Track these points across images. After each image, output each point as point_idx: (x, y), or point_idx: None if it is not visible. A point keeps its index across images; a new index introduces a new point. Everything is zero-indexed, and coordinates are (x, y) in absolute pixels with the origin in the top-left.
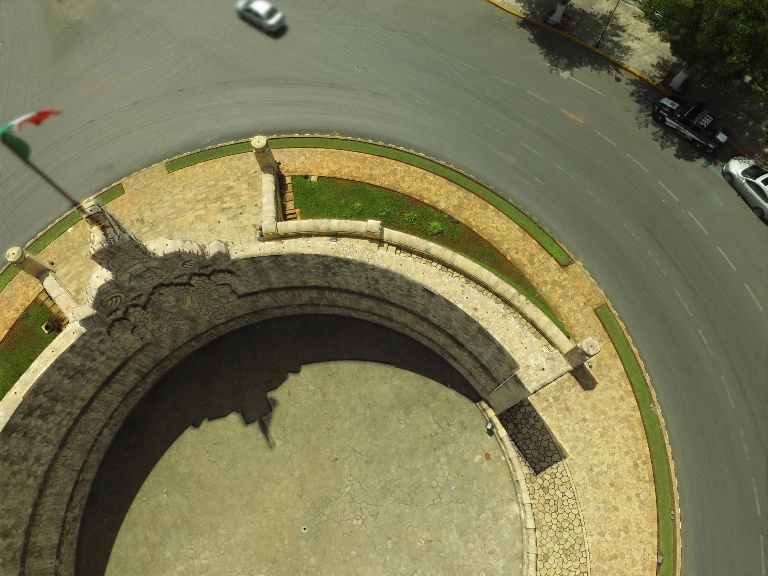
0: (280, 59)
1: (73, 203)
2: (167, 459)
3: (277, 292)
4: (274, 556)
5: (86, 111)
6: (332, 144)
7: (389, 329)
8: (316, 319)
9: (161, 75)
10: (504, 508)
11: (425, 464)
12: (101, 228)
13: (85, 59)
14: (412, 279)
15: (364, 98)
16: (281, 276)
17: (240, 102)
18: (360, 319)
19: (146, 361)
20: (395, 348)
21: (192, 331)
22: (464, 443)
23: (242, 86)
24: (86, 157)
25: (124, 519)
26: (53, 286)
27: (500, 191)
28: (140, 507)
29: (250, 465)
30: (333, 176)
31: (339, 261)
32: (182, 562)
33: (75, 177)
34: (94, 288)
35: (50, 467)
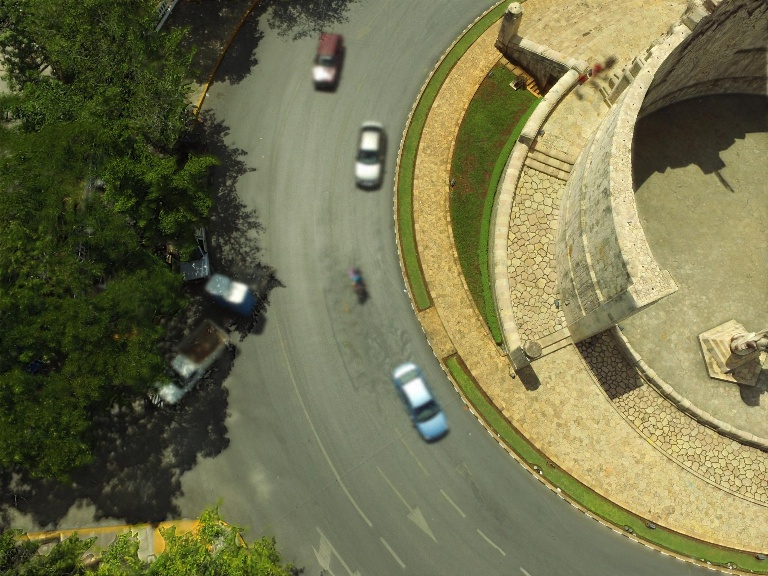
0: None
1: None
2: (641, 195)
3: (766, 52)
4: (749, 273)
5: None
6: None
7: None
8: (751, 99)
9: None
10: None
11: None
12: None
13: None
14: None
15: None
16: None
17: None
18: None
19: (644, 103)
20: None
21: (675, 85)
22: None
23: None
24: None
25: None
26: (536, 44)
27: None
28: None
29: (714, 205)
30: None
31: None
32: (670, 270)
33: None
34: None
35: None
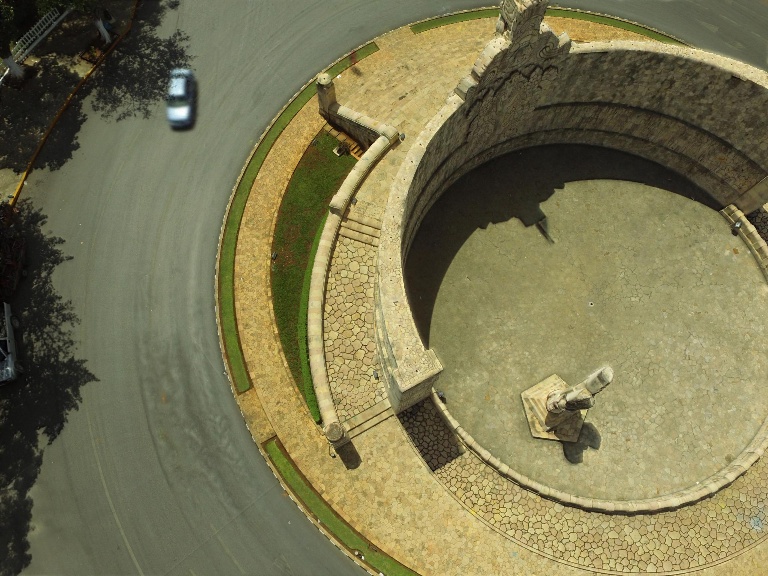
0: None
1: (334, 57)
2: (463, 253)
3: (564, 107)
4: (570, 324)
5: None
6: (555, 13)
7: (634, 156)
8: (569, 148)
9: None
10: (756, 288)
11: (684, 257)
12: None
13: None
14: (723, 68)
15: None
16: (582, 85)
17: None
18: (608, 148)
19: (453, 164)
20: (642, 170)
21: (484, 144)
22: (714, 241)
23: None
24: (338, 20)
25: (436, 297)
26: (351, 111)
27: None
28: (448, 288)
29: (535, 257)
30: None
31: (653, 59)
32: (493, 328)
33: (332, 36)
34: (490, 57)
35: (405, 232)
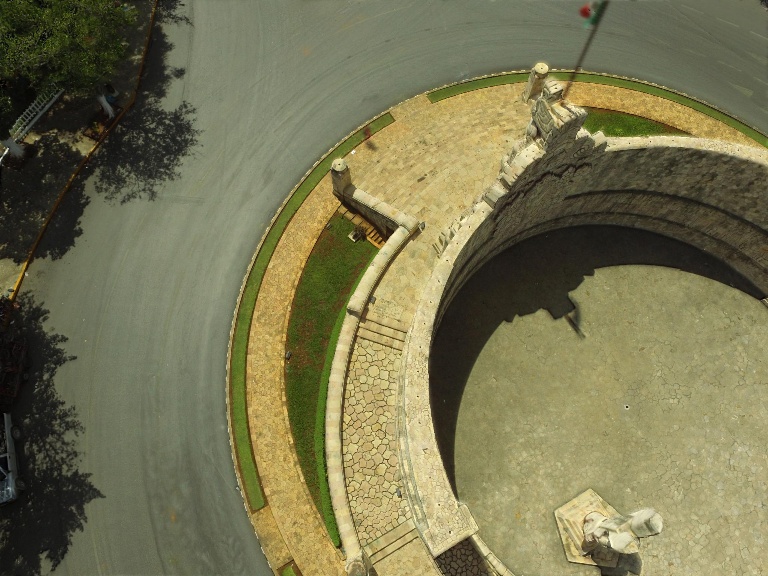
0: (515, 2)
1: (348, 130)
2: (489, 349)
3: (595, 195)
4: (605, 430)
5: (342, 48)
6: (579, 78)
7: (668, 238)
8: (599, 229)
9: (406, 16)
10: None
11: (725, 352)
12: (561, 105)
13: (331, 1)
14: None
15: (601, 37)
16: (616, 176)
17: (485, 41)
18: (640, 229)
19: (477, 258)
20: (676, 254)
21: (510, 233)
22: (756, 334)
23: (484, 26)
24: (351, 89)
25: (461, 400)
26: (367, 196)
27: (743, 119)
28: (473, 390)
29: (566, 354)
30: (589, 105)
31: (695, 155)
32: (522, 435)
33: (345, 107)
34: (521, 166)
35: None
